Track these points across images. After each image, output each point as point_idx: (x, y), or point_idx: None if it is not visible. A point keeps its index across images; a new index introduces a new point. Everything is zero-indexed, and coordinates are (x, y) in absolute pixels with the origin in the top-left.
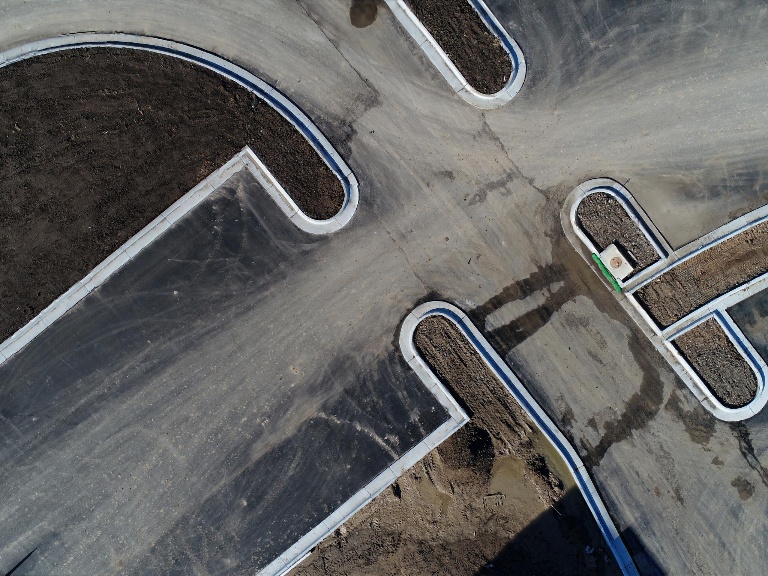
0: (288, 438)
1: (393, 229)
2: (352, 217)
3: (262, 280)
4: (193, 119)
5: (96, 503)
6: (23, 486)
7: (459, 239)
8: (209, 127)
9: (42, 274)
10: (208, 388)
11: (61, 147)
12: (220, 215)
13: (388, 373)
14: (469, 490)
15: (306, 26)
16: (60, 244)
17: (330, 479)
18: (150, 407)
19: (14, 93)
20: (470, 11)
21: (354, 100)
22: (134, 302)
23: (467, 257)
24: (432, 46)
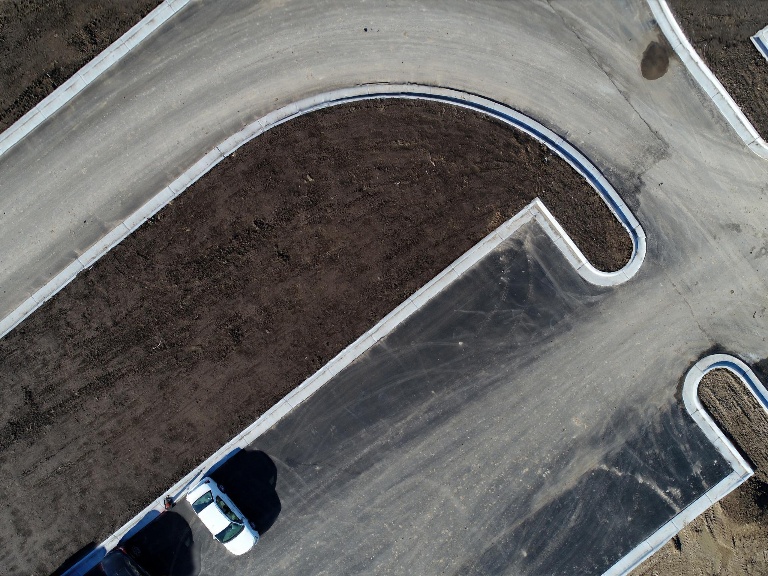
0: (569, 490)
1: (679, 282)
2: (639, 269)
3: (547, 332)
4: (485, 171)
5: (376, 552)
6: (305, 535)
7: (744, 292)
8: (500, 179)
9: (331, 324)
10: (491, 439)
11: (353, 198)
12: (507, 266)
13: (670, 426)
14: (750, 544)
15: (597, 78)
16: (349, 294)
17: (611, 531)
18: (432, 457)
19: (307, 143)
20: (764, 64)
21: (644, 152)
22: (419, 352)
23: (752, 310)
24: (724, 99)
